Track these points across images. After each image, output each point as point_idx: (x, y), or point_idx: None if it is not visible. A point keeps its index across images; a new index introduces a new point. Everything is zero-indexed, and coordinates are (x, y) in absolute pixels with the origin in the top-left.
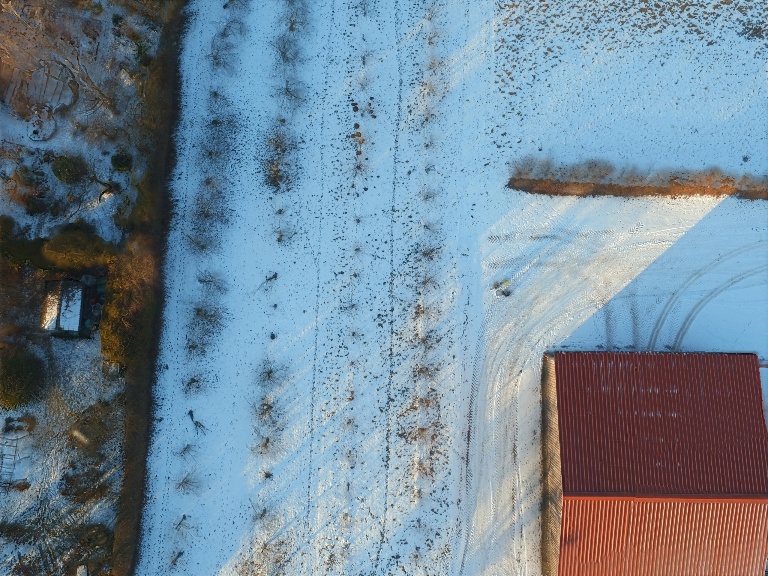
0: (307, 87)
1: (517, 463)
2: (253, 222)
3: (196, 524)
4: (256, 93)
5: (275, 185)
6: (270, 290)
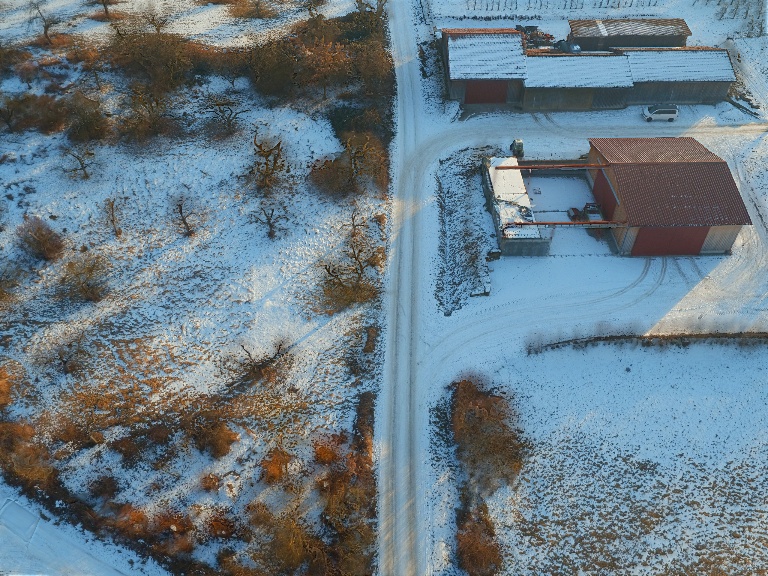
0: None
1: None
2: None
3: None
4: None
5: None
6: None
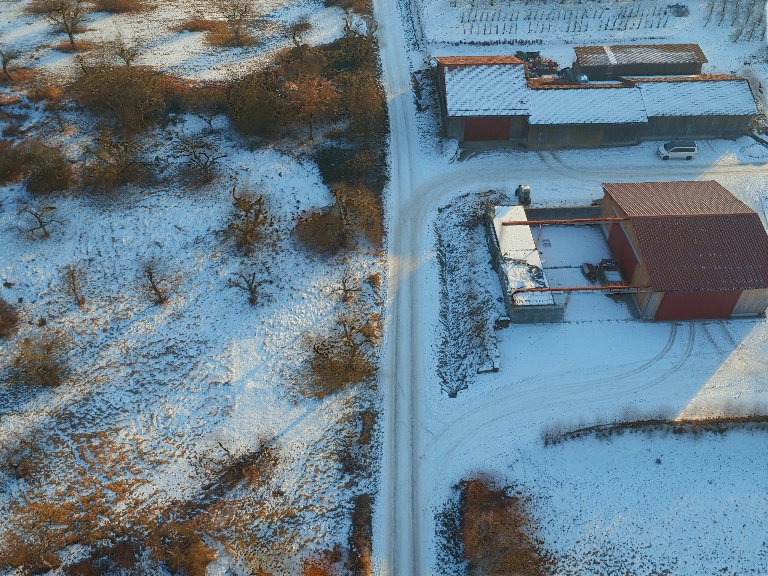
0: None
1: None
2: None
3: None
4: None
5: None
6: None
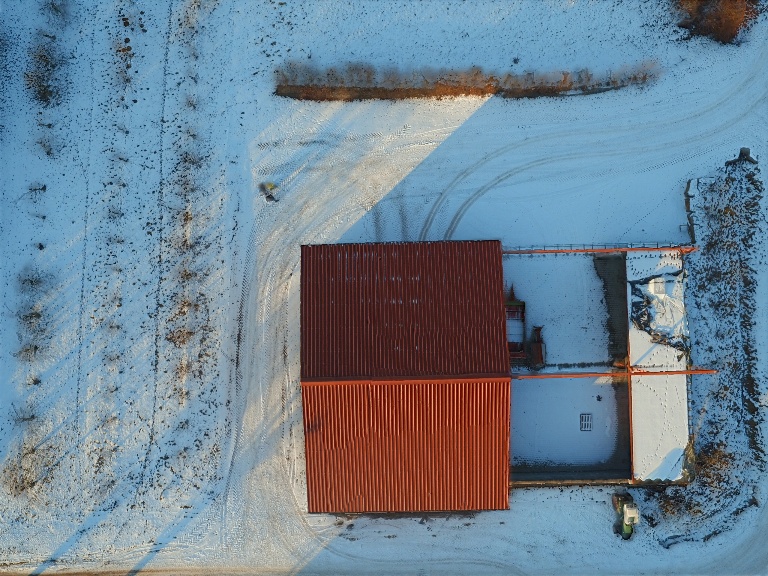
0: (78, 4)
1: (287, 364)
2: (23, 137)
3: None
4: (27, 11)
5: (45, 100)
6: (39, 202)
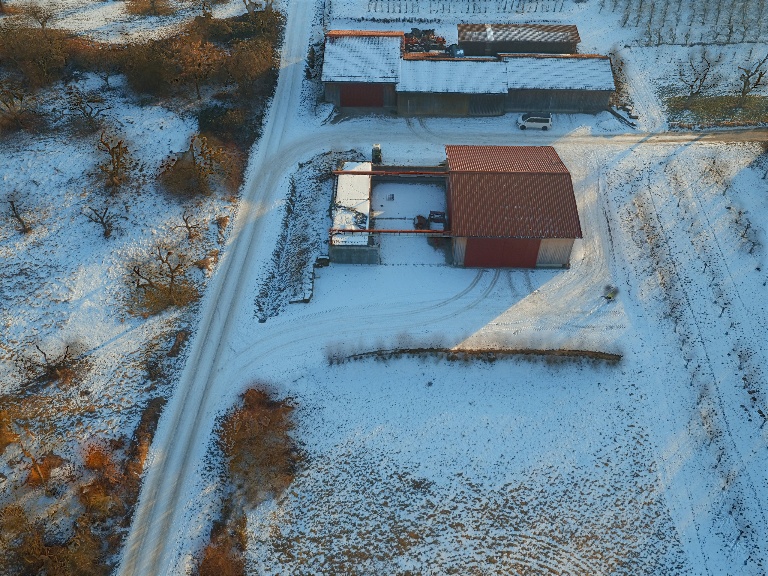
0: None
1: None
2: None
3: (761, 189)
4: None
5: None
6: None
